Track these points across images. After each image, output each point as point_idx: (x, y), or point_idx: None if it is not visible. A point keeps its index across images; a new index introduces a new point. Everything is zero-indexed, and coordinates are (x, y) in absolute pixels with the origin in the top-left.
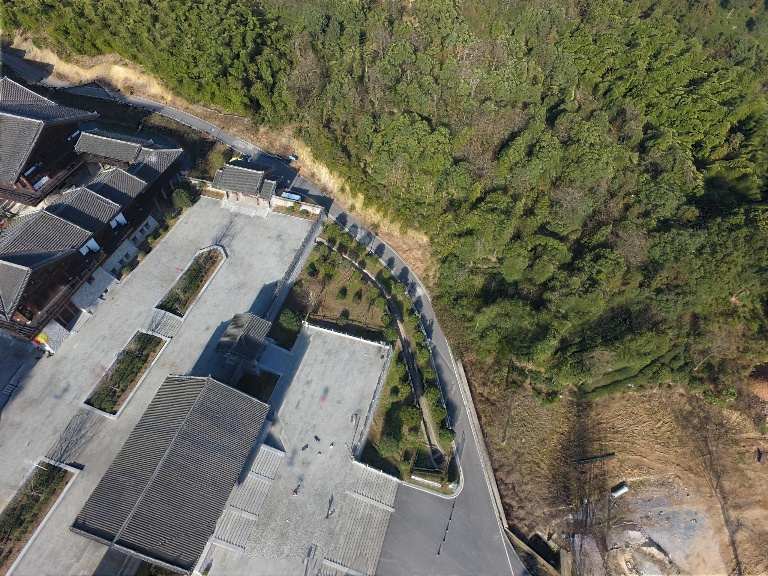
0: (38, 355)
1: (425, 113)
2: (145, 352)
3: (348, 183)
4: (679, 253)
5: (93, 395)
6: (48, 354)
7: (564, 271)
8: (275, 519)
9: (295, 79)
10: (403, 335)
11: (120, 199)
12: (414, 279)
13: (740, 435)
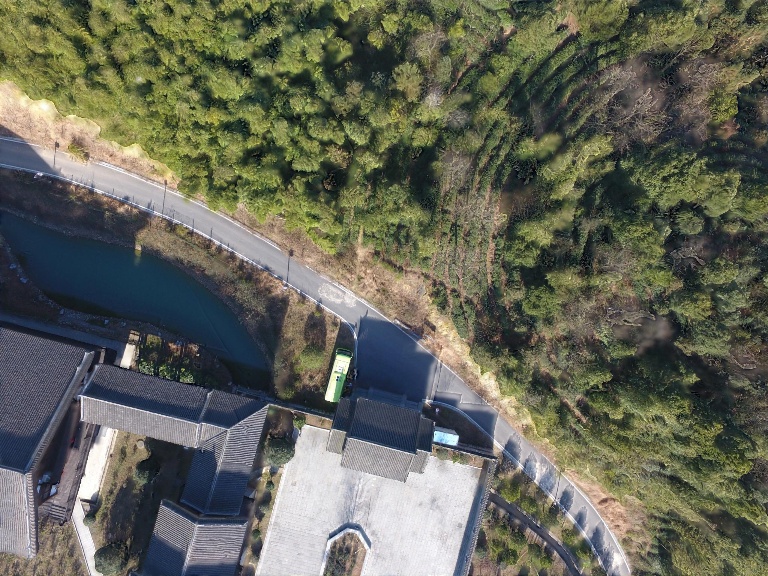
0: None
1: (704, 353)
2: None
3: None
4: None
5: None
6: None
7: None
8: None
9: (418, 145)
10: None
11: (221, 572)
12: (611, 542)
13: None
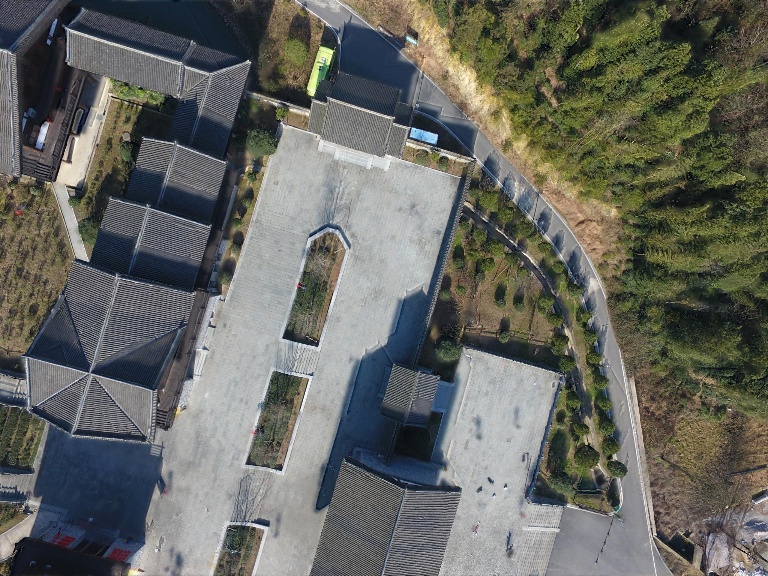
0: None
1: None
2: (289, 397)
3: None
4: None
5: (251, 452)
6: (180, 407)
7: None
8: (460, 555)
9: None
10: (570, 344)
11: (200, 204)
12: (588, 266)
13: None
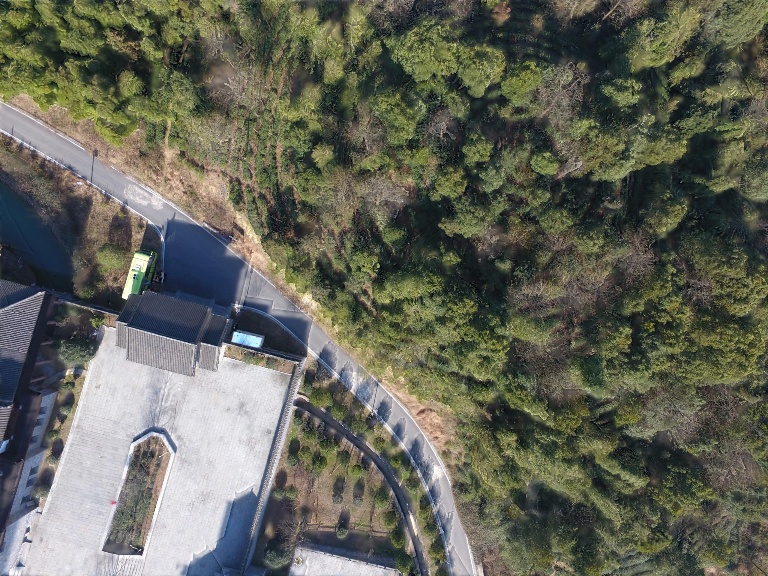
0: None
1: (468, 235)
2: None
3: None
4: None
5: None
6: None
7: (631, 506)
8: None
9: None
10: (416, 531)
11: None
12: (431, 454)
13: None
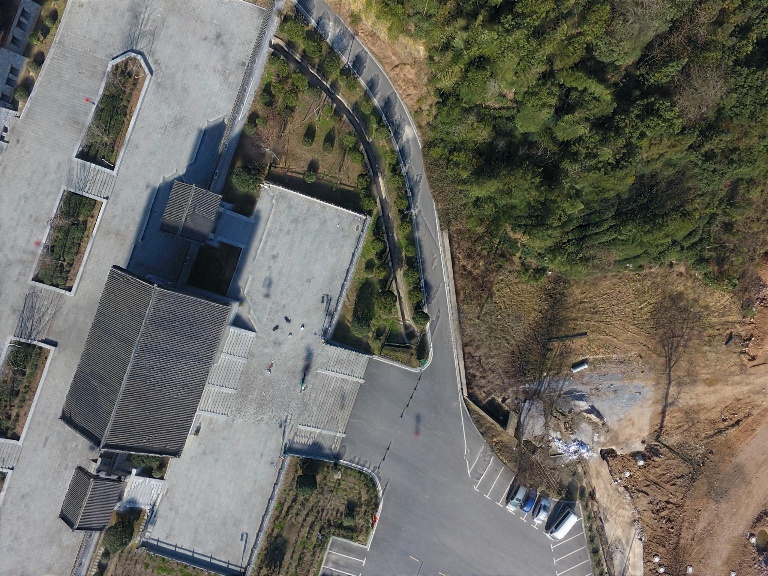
0: None
1: None
2: (81, 218)
3: None
4: (761, 109)
5: (39, 270)
6: None
7: (597, 132)
8: (252, 393)
9: None
10: (384, 194)
11: None
12: (403, 113)
13: (720, 318)
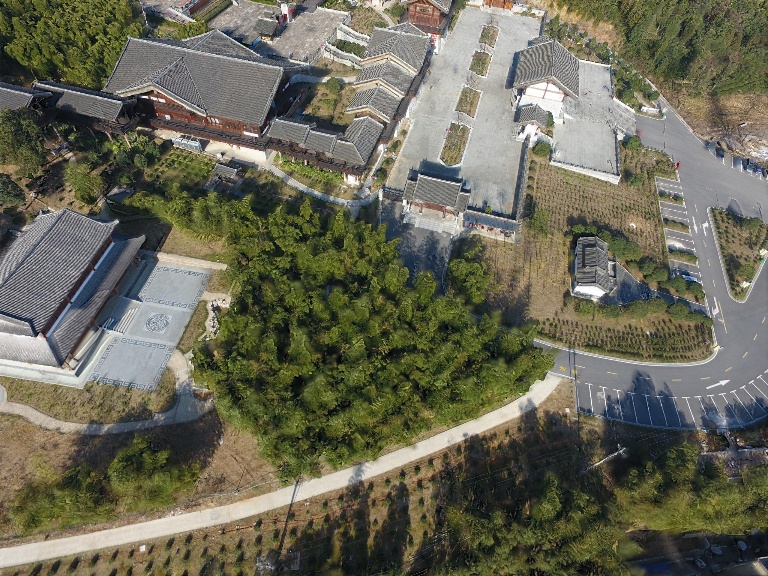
0: (430, 54)
1: None
2: None
3: (557, 0)
4: (762, 27)
5: (470, 69)
6: (435, 54)
7: None
8: (586, 112)
9: None
10: None
11: None
12: None
13: None
